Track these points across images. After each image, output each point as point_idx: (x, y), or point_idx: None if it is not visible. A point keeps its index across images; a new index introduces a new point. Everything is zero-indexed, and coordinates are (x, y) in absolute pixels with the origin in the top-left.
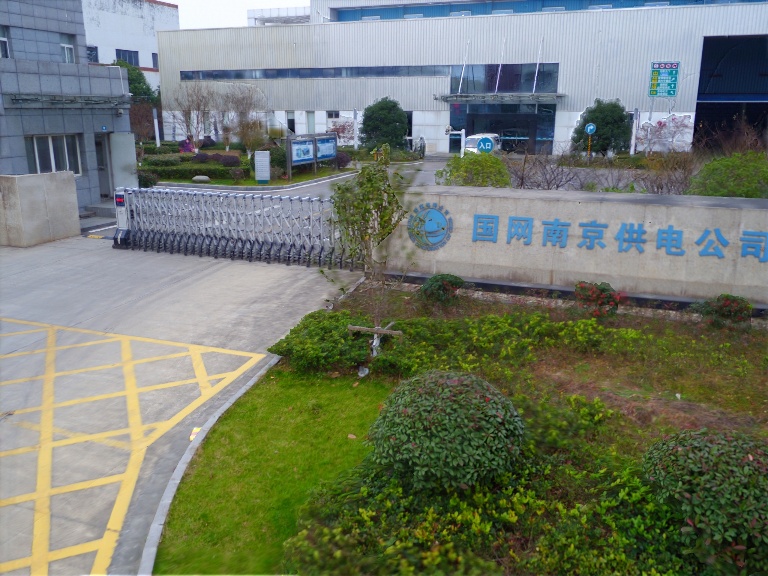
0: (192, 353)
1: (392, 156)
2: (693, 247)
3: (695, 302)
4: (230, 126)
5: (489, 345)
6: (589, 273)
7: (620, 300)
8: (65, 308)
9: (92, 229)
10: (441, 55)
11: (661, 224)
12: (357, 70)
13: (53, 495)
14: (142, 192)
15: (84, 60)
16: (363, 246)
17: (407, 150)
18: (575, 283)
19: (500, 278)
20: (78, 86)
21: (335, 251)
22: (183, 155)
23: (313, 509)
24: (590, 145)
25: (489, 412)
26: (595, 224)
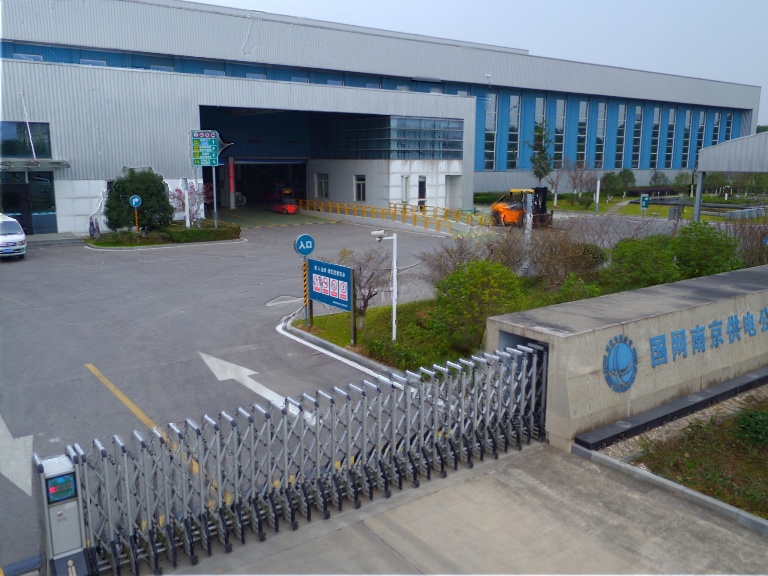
0: None
1: None
2: (759, 326)
3: None
4: None
5: None
6: (720, 369)
7: (750, 386)
8: None
9: None
10: None
11: (744, 312)
12: None
13: None
14: None
15: None
16: None
17: None
18: (713, 382)
19: (672, 399)
20: None
21: None
22: None
23: None
24: (137, 219)
25: None
26: (716, 323)
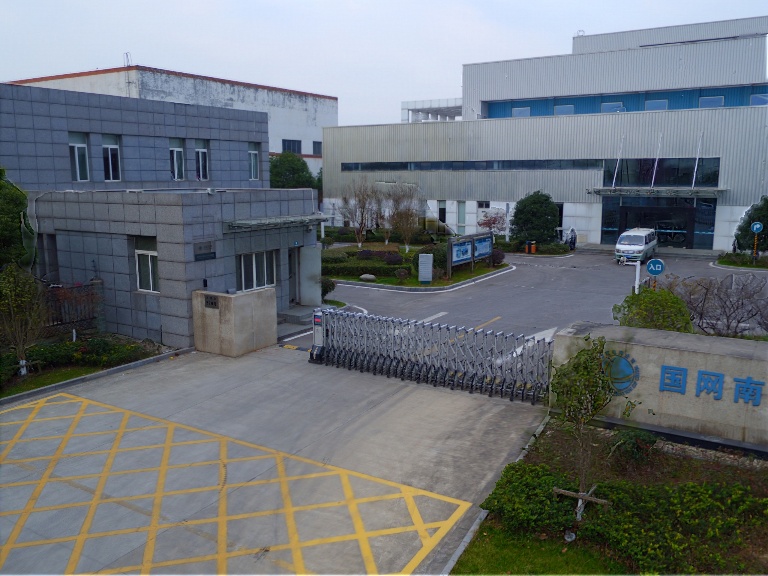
0: (405, 495)
1: (543, 249)
2: None
3: None
4: (390, 221)
5: (694, 521)
6: None
7: None
8: (284, 432)
9: (286, 338)
10: (594, 149)
11: None
12: (509, 163)
13: None
14: (338, 314)
15: (266, 164)
16: (544, 380)
17: (557, 241)
18: None
19: (688, 429)
20: (279, 209)
21: (516, 383)
22: (349, 250)
23: None
24: (756, 244)
25: None
26: None
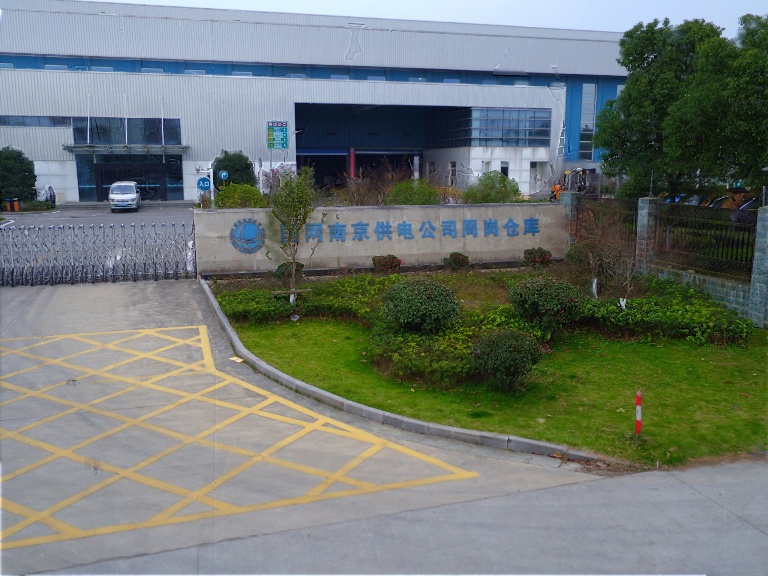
0: (148, 333)
1: (28, 206)
2: (418, 233)
3: (431, 263)
4: None
5: None
6: (362, 256)
7: None
8: None
9: None
10: (60, 107)
11: (399, 221)
12: None
13: (202, 395)
14: None
15: None
16: (180, 259)
17: None
18: (354, 264)
19: (304, 267)
20: None
21: None
22: None
23: (384, 350)
24: None
25: (446, 288)
26: (361, 224)
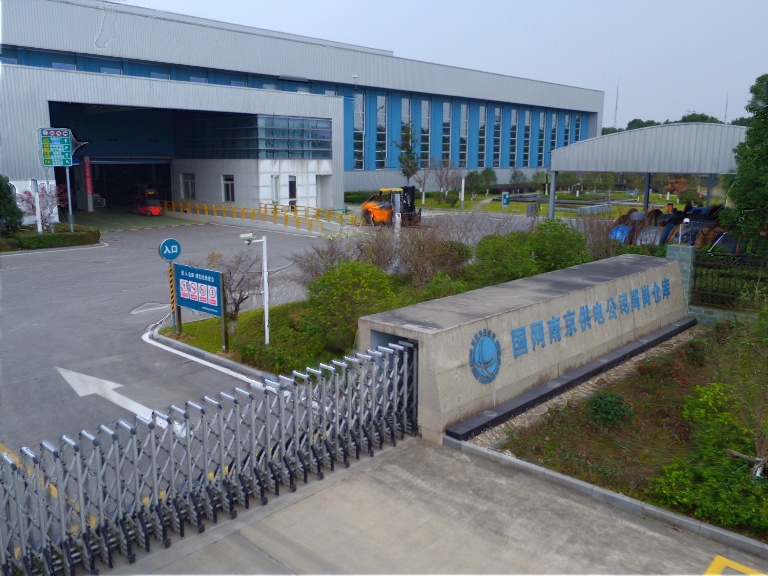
0: None
1: None
2: (606, 314)
3: None
4: None
5: None
6: (574, 356)
7: (600, 370)
8: None
9: None
10: None
11: (593, 302)
12: None
13: None
14: None
15: None
16: None
17: None
18: None
19: (533, 386)
20: None
21: None
22: None
23: None
24: None
25: None
26: (570, 313)
